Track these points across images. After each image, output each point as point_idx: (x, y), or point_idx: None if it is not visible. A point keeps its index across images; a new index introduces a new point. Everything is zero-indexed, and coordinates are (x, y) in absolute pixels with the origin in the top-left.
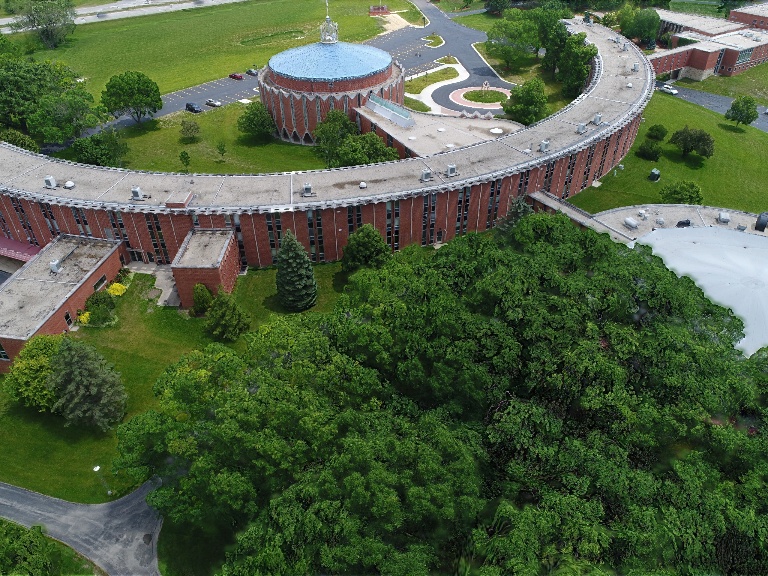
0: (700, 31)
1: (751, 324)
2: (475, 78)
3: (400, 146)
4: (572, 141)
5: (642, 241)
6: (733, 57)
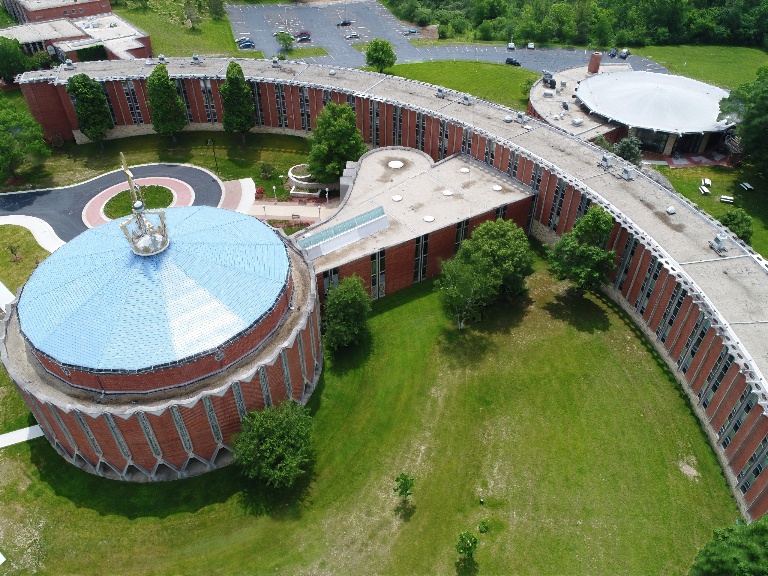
0: (68, 38)
1: (694, 102)
2: (41, 210)
3: (447, 231)
4: (492, 109)
5: (613, 118)
6: (146, 44)
